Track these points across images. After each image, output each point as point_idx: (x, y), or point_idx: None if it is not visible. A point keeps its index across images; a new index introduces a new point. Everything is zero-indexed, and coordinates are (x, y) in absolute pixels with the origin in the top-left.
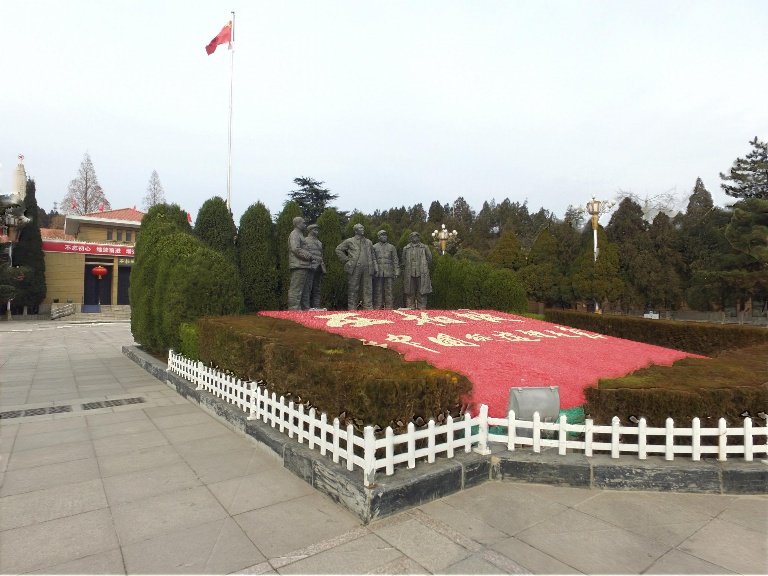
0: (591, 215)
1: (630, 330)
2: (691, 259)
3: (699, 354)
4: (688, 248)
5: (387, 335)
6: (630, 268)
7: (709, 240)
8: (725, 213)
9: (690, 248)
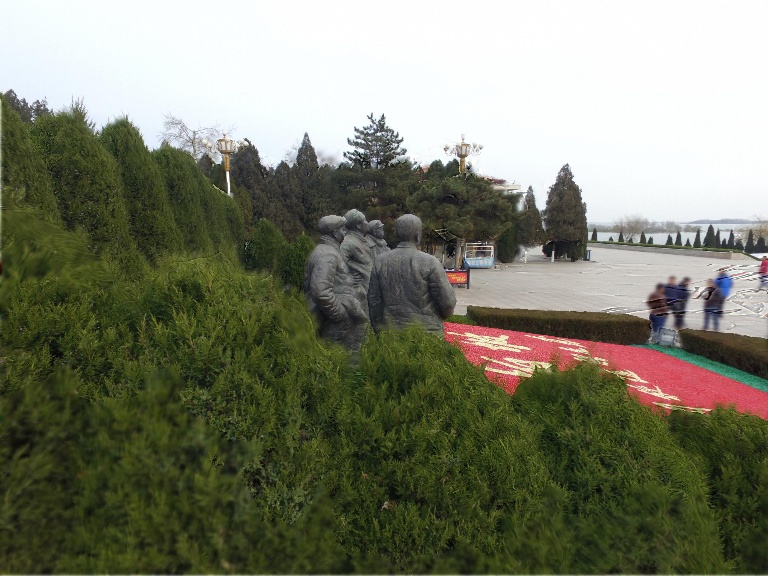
0: (222, 154)
1: (566, 328)
2: (310, 210)
3: (611, 342)
4: (308, 200)
5: None
6: (264, 216)
7: (326, 194)
8: (352, 175)
9: (310, 200)
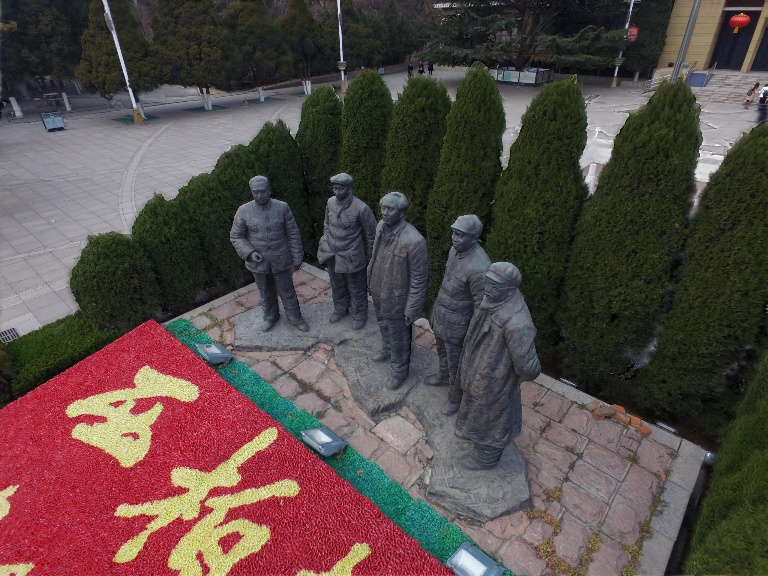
0: None
1: None
2: None
3: None
4: None
5: (8, 486)
6: None
7: None
8: None
9: None
